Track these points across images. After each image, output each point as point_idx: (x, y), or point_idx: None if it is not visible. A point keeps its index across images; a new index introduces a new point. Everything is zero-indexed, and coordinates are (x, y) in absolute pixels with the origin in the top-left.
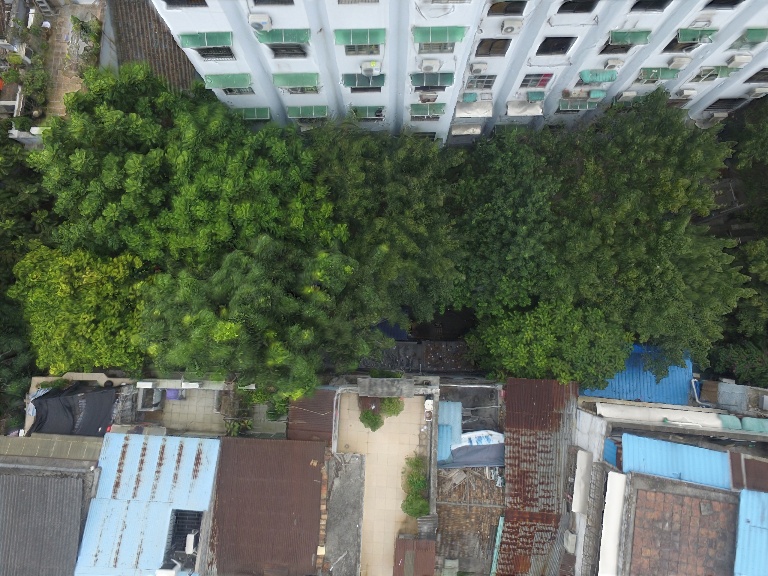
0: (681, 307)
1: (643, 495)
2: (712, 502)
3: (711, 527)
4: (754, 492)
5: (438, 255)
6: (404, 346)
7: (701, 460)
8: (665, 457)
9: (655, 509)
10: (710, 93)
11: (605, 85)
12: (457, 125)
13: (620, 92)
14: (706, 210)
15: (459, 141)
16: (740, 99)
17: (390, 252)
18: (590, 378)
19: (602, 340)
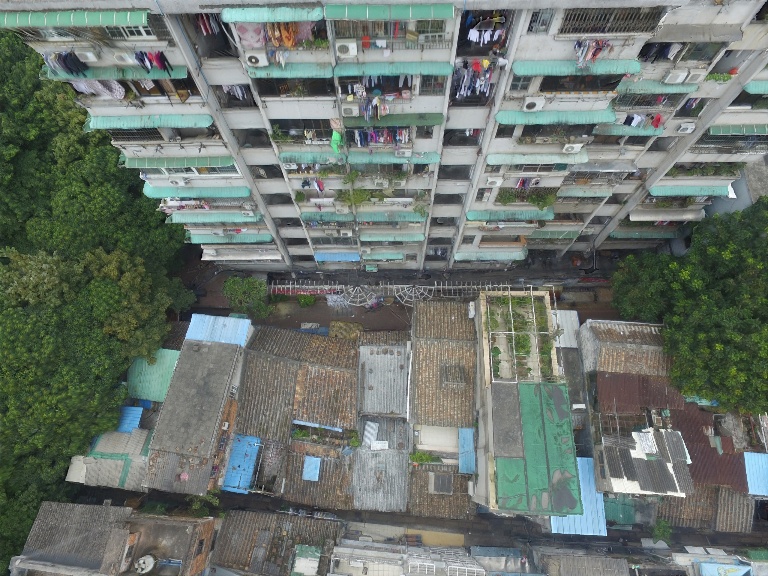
0: None
1: None
2: None
3: None
4: None
5: None
6: None
7: None
8: None
9: None
10: None
11: None
12: None
13: None
14: None
15: None
16: None
17: None
18: None
19: None
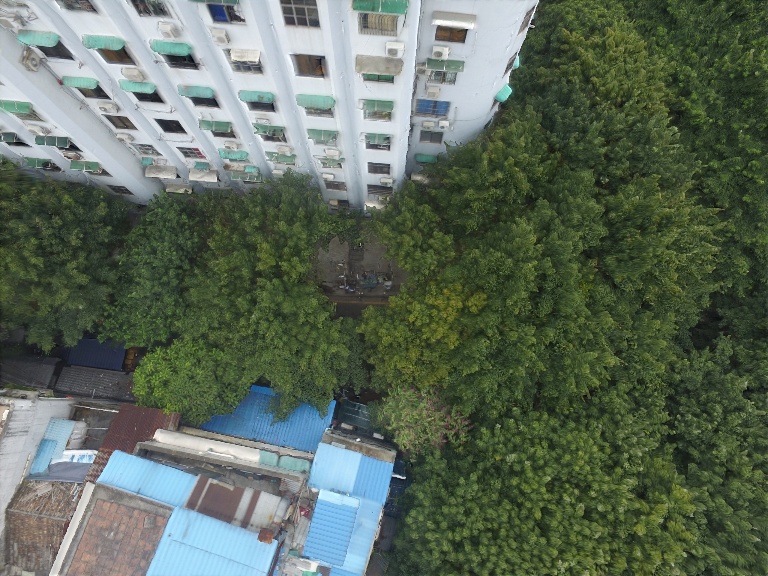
0: (281, 355)
1: (100, 504)
2: (157, 517)
3: (149, 540)
4: (185, 509)
5: (60, 285)
6: (111, 375)
7: (171, 480)
8: (141, 474)
9: (106, 518)
10: (358, 179)
11: None
12: (171, 184)
13: None
14: (293, 271)
15: None
16: (389, 187)
17: (3, 277)
18: (194, 411)
19: (199, 376)
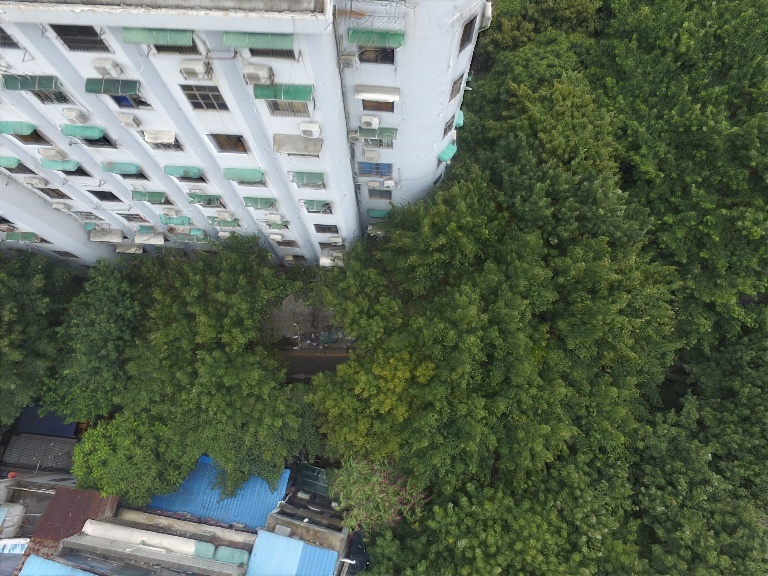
0: (224, 430)
1: None
2: None
3: None
4: None
5: None
6: (61, 443)
7: None
8: None
9: None
10: (309, 237)
11: None
12: None
13: (219, 231)
14: (234, 343)
15: (140, 256)
16: None
17: None
18: None
19: (137, 456)
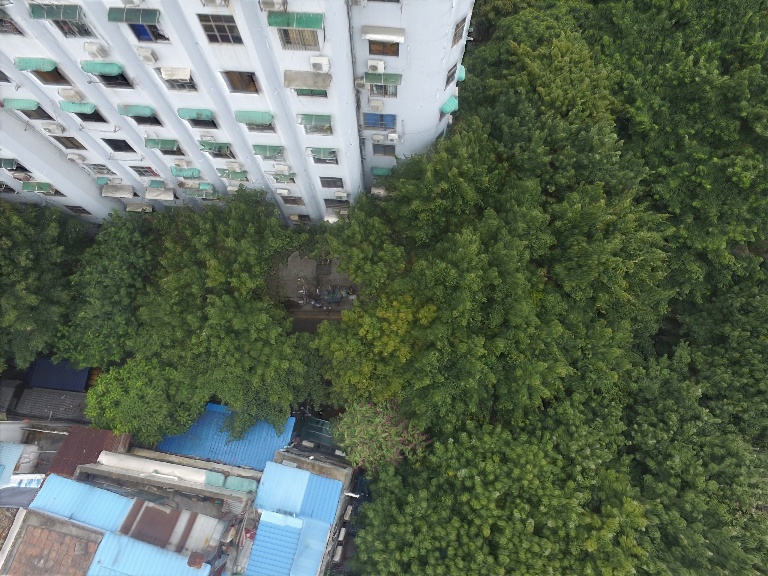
0: (233, 372)
1: (31, 531)
2: (88, 542)
3: (80, 567)
4: (116, 534)
5: (8, 307)
6: (72, 396)
7: (106, 504)
8: (76, 498)
9: (36, 545)
10: (314, 193)
11: (208, 180)
12: (131, 203)
13: None
14: (243, 287)
15: None
16: (346, 200)
17: None
18: (144, 432)
19: (149, 396)
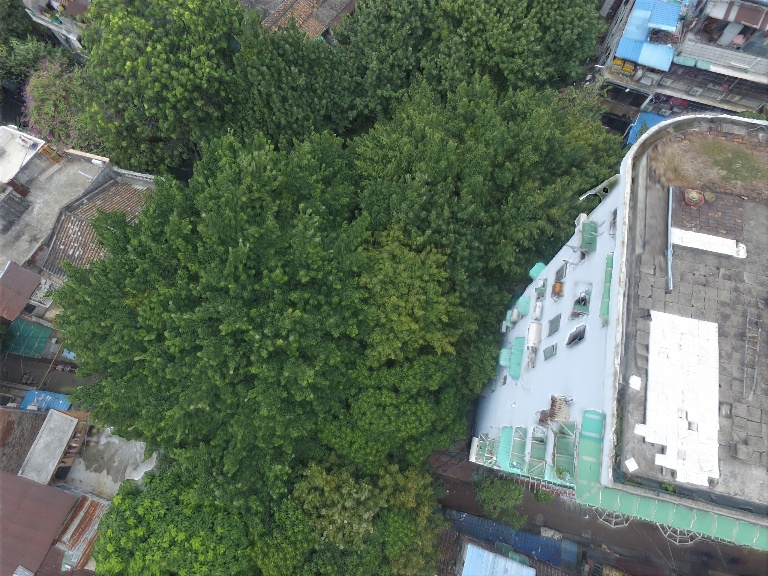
0: None
1: None
2: None
3: None
4: None
5: None
6: None
7: None
8: None
9: None
10: None
11: None
12: None
13: None
14: None
15: None
16: None
17: None
18: None
19: None
